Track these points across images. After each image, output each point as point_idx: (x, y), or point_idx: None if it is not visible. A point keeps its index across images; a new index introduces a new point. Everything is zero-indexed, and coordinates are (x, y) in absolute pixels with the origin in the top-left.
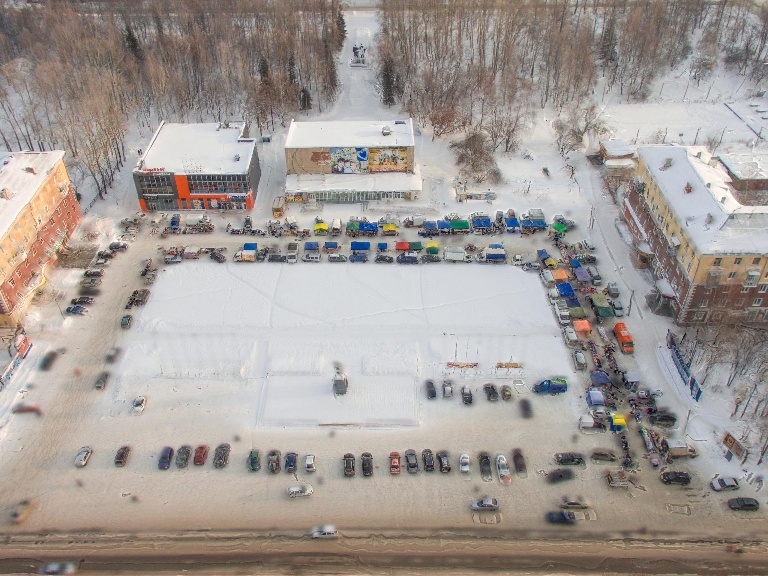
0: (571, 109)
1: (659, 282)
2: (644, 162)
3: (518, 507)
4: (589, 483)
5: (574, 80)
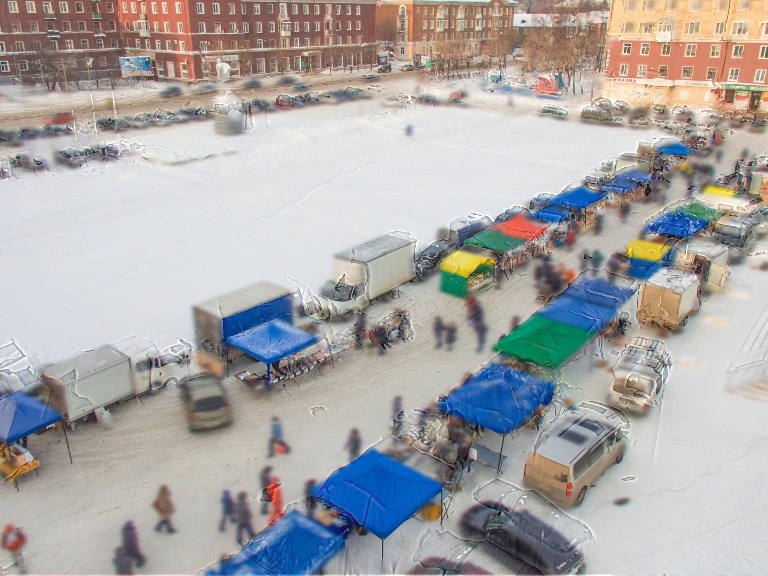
0: None
1: None
2: None
3: None
4: None
5: None
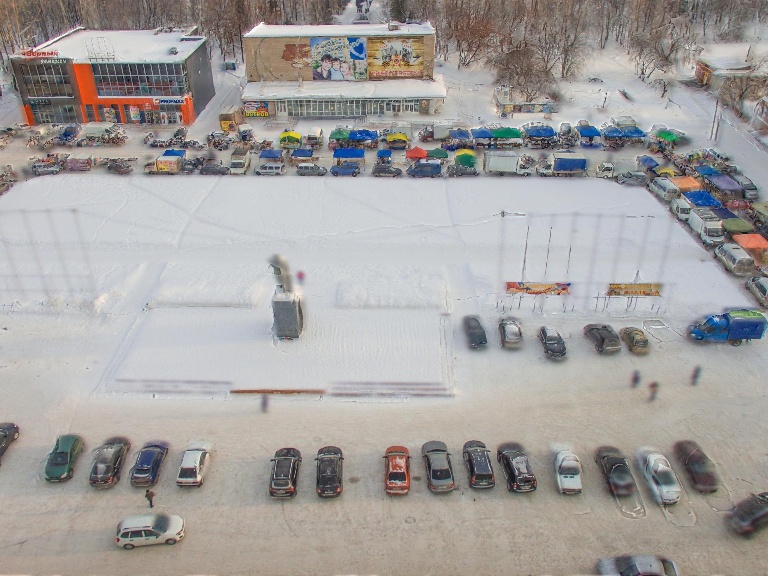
0: None
1: None
2: None
3: None
4: None
5: (645, 6)
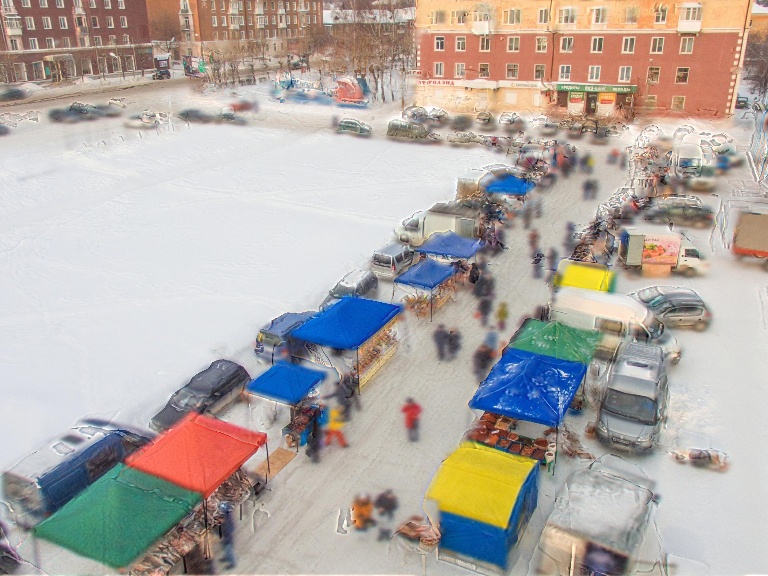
0: None
1: None
2: None
3: None
4: None
5: None
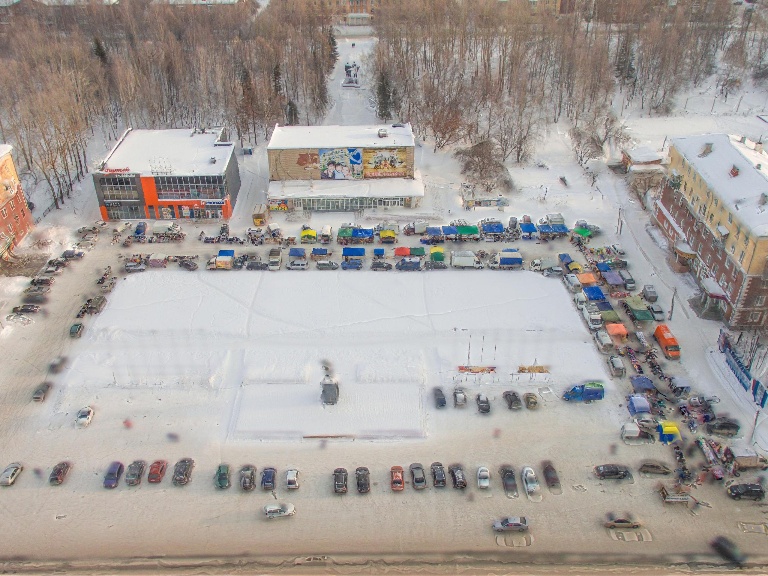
0: (587, 121)
1: (704, 281)
2: (679, 151)
3: (552, 527)
4: (639, 499)
5: (590, 90)
